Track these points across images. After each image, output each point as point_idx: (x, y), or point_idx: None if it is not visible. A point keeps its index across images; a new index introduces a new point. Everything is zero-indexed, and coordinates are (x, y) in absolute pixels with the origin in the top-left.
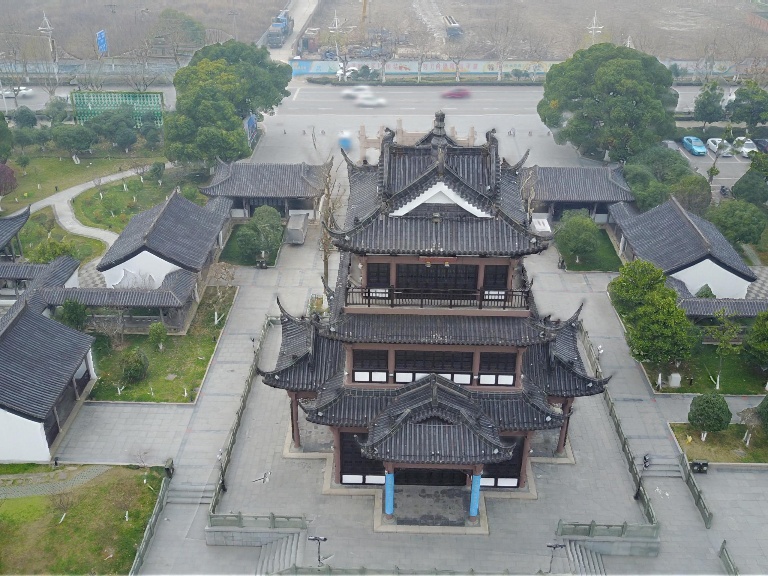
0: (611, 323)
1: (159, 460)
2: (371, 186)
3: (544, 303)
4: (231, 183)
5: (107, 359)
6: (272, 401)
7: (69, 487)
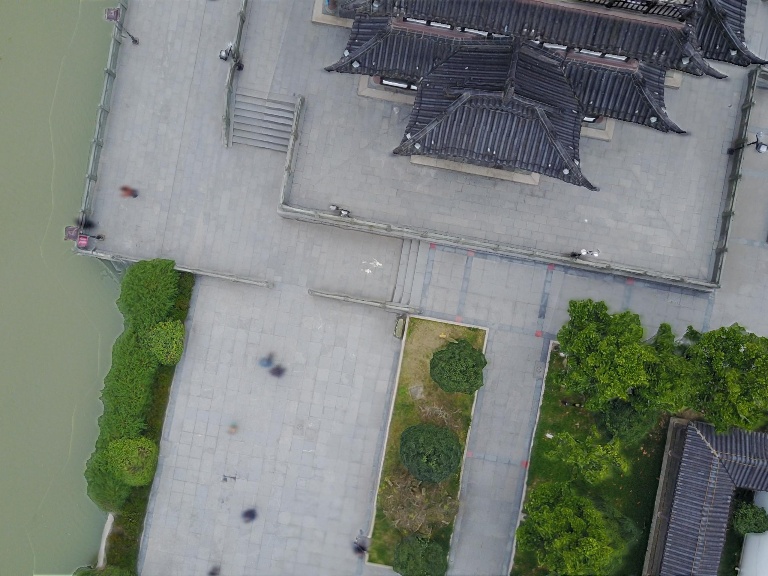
0: None
1: None
2: None
3: None
4: None
5: None
6: None
7: None
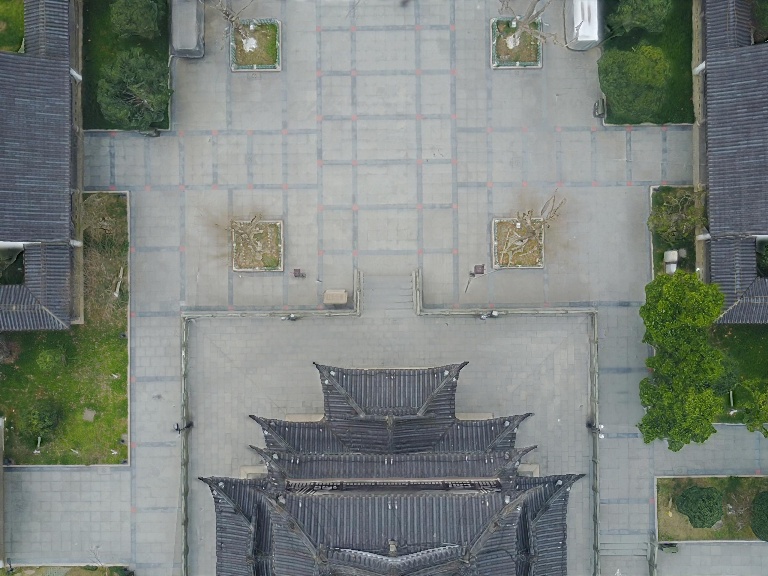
0: (639, 267)
1: (115, 557)
2: (303, 574)
3: (557, 218)
4: None
5: (1, 382)
6: (216, 476)
7: None
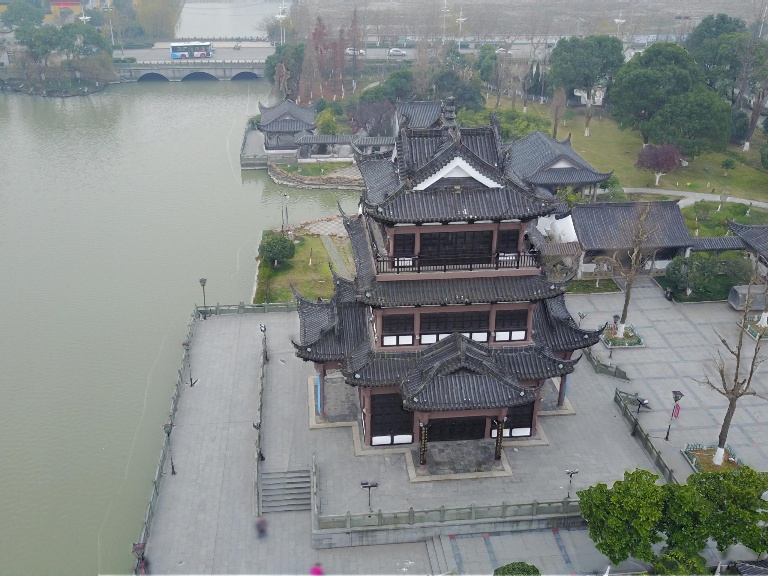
0: (752, 552)
1: None
2: None
3: None
4: (762, 232)
5: None
6: None
7: (346, 277)
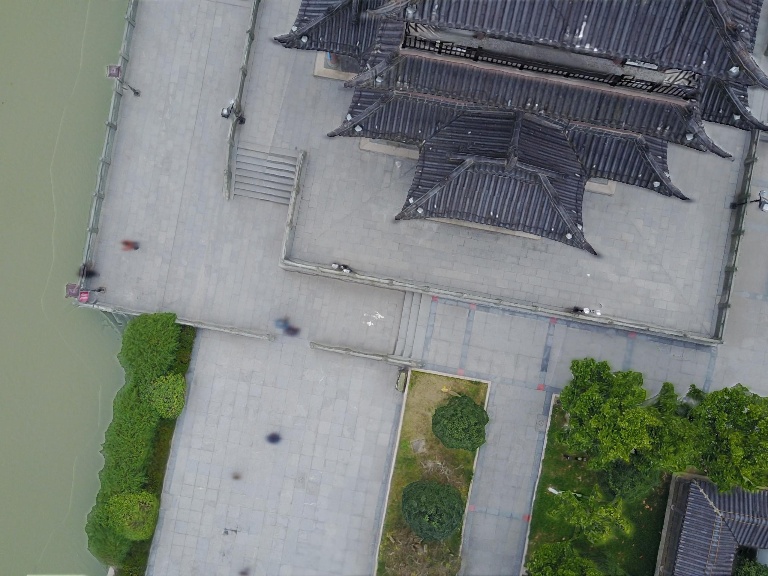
0: None
1: None
2: None
3: None
4: None
5: None
6: None
7: None
